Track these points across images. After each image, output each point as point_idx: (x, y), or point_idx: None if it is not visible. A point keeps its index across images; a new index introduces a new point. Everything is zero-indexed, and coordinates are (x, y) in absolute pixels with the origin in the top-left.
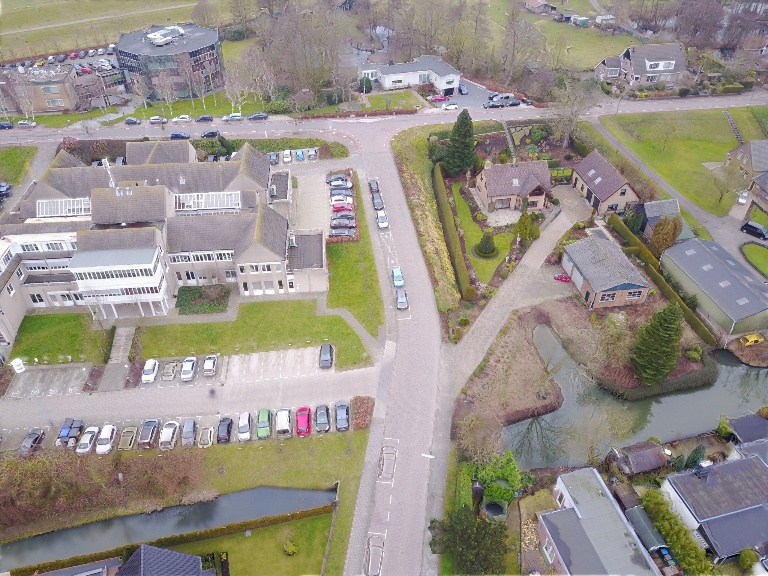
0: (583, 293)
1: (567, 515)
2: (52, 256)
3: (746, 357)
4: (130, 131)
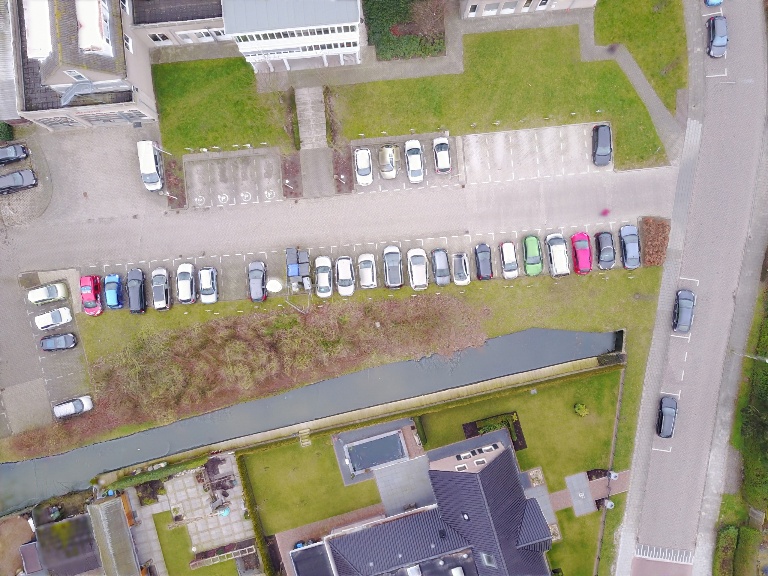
0: None
1: None
2: None
3: None
4: None
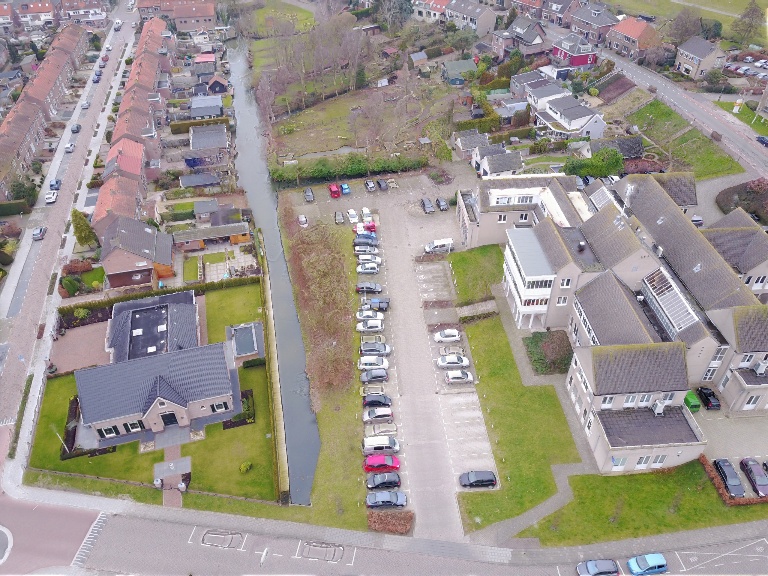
0: None
1: None
2: None
3: None
4: None
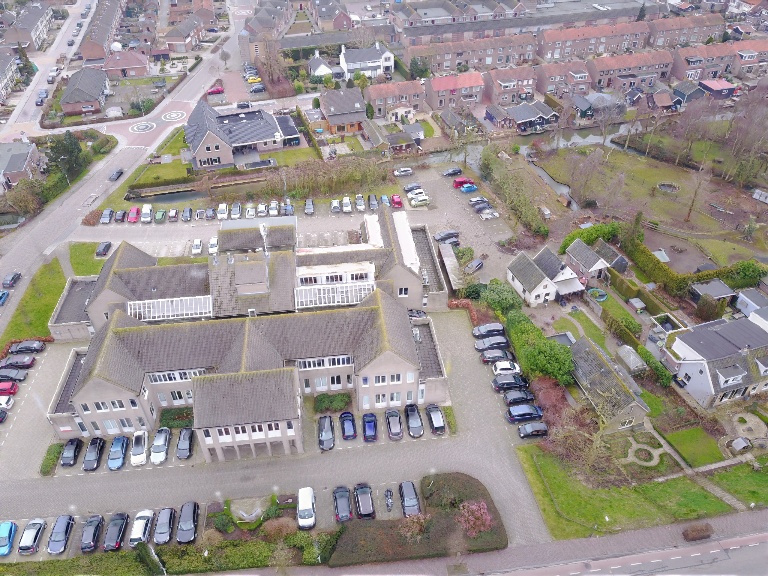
0: None
1: None
2: None
3: None
4: None
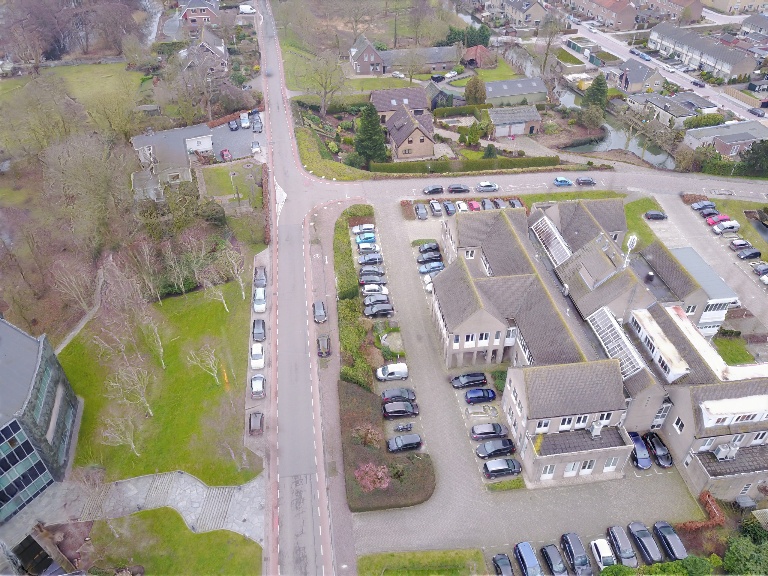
0: (527, 132)
1: (721, 138)
2: None
3: (556, 103)
4: (292, 419)
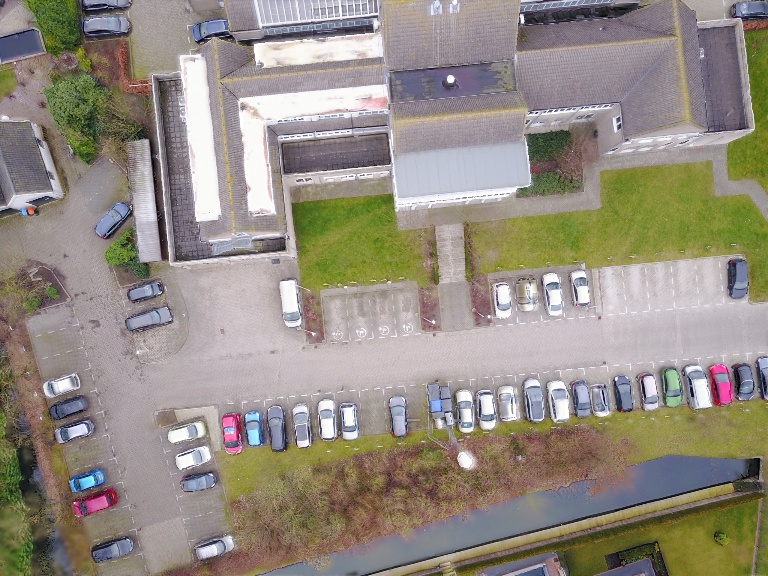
0: None
1: None
2: (325, 127)
3: None
4: None
